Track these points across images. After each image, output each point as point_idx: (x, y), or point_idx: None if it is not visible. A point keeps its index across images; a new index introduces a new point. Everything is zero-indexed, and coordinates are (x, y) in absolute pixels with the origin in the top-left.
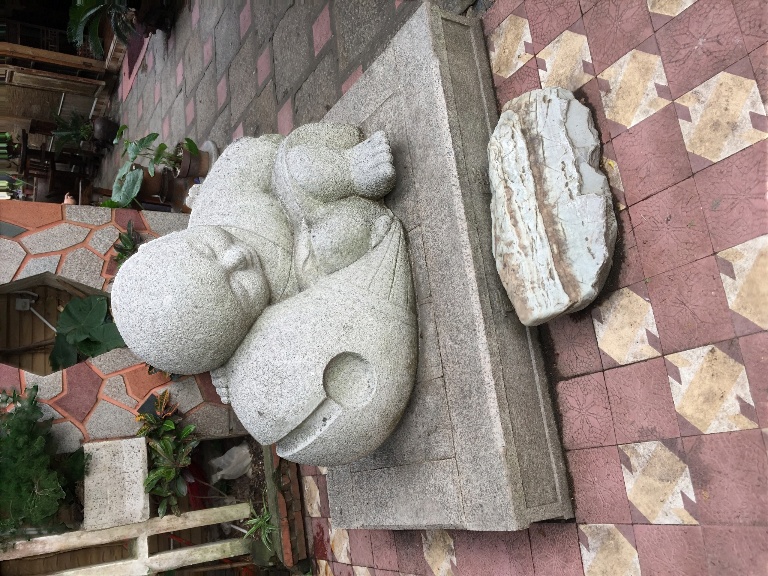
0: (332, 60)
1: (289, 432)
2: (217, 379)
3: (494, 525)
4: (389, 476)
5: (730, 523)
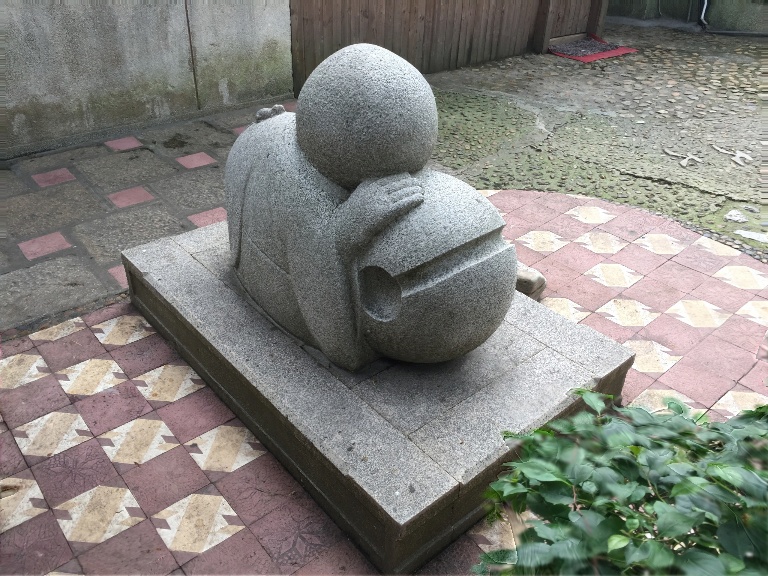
0: (77, 259)
1: (501, 226)
2: (409, 178)
3: (620, 359)
4: (479, 400)
5: (693, 347)
